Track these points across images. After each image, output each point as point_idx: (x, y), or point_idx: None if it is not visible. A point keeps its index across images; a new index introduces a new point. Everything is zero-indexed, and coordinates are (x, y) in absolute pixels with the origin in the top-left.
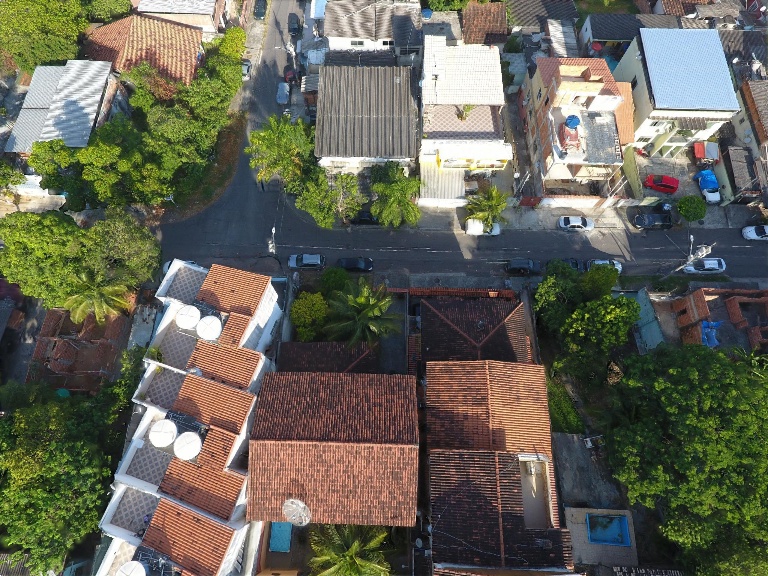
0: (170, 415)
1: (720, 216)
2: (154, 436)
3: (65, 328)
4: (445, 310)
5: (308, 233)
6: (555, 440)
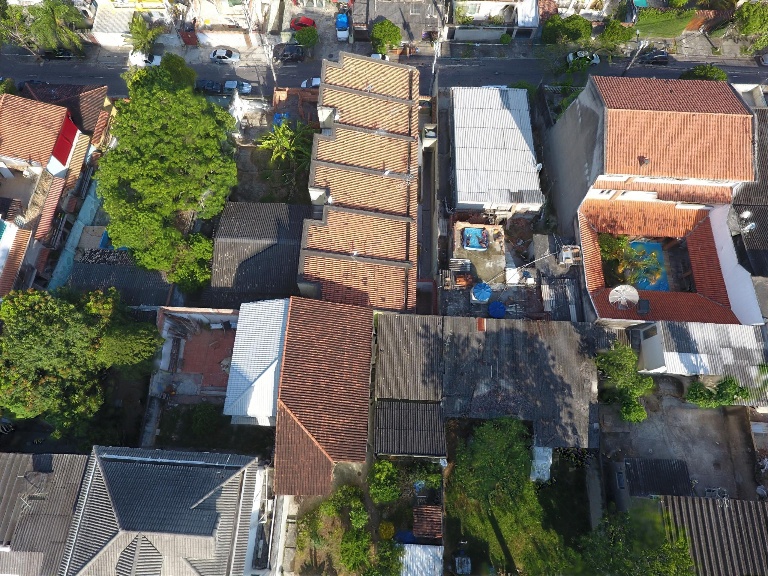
0: None
1: (348, 51)
2: None
3: None
4: (38, 88)
5: (7, 67)
6: None
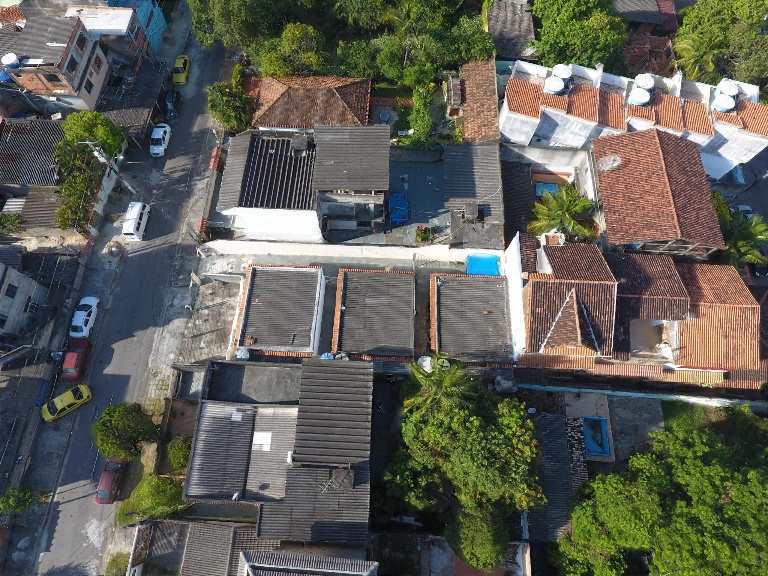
0: (652, 88)
1: None
2: (642, 76)
3: (652, 53)
4: None
5: None
6: (656, 409)
